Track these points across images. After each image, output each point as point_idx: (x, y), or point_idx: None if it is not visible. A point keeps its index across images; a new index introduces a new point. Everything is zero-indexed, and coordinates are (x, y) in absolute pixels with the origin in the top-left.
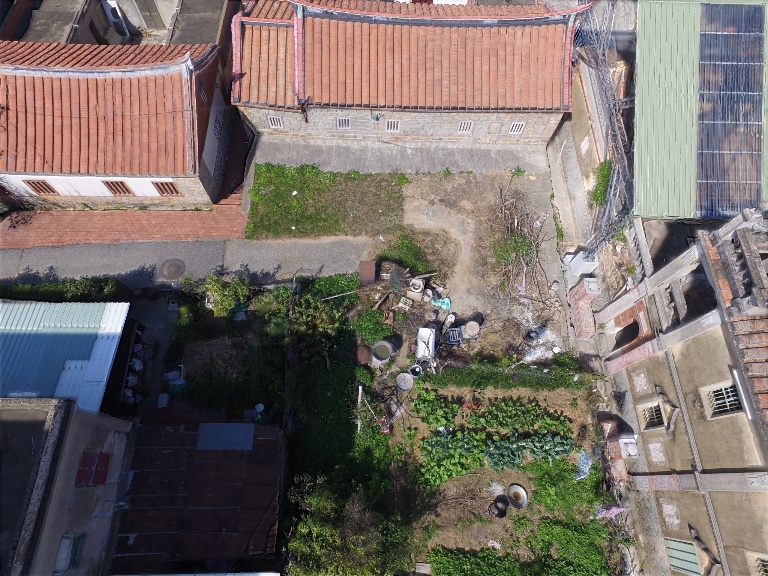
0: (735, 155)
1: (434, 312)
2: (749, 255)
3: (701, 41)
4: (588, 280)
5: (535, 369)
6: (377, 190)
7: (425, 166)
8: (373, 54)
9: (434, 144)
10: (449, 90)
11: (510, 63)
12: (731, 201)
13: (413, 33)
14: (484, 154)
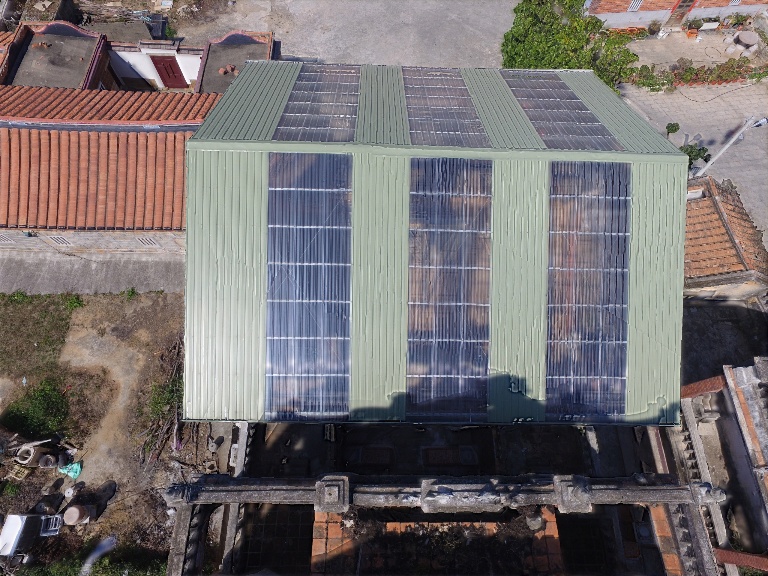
0: (315, 342)
1: (57, 482)
2: (172, 549)
3: (271, 199)
4: (236, 447)
5: (141, 569)
6: (41, 316)
7: (107, 285)
8: (13, 164)
9: (126, 256)
10: (105, 207)
11: (179, 175)
12: (310, 399)
13: (63, 139)
14: (183, 268)
